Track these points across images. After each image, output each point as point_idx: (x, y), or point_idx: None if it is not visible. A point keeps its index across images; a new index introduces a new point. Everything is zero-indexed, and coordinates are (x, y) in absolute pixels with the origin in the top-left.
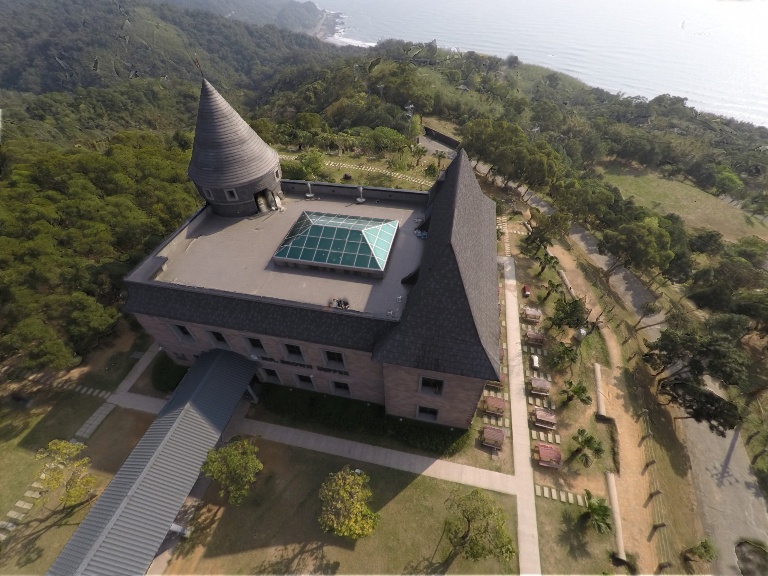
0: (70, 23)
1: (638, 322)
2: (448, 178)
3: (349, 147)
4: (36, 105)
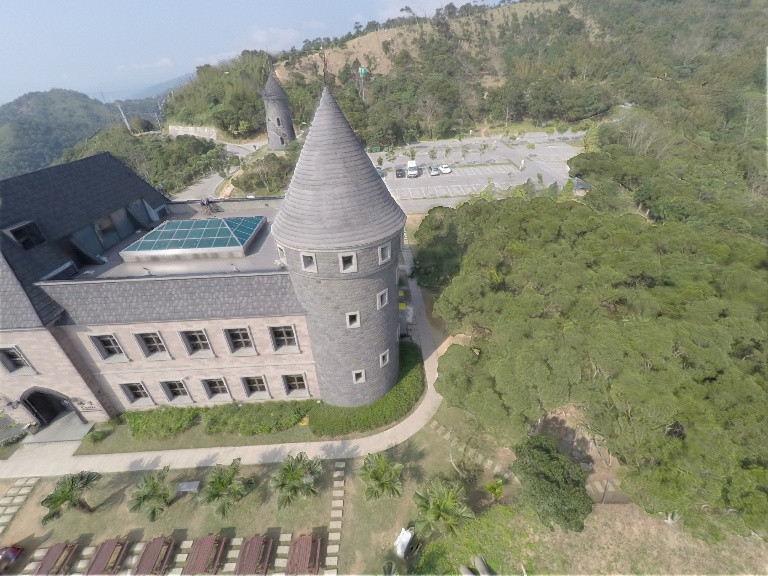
0: None
1: None
2: (24, 209)
3: None
4: None
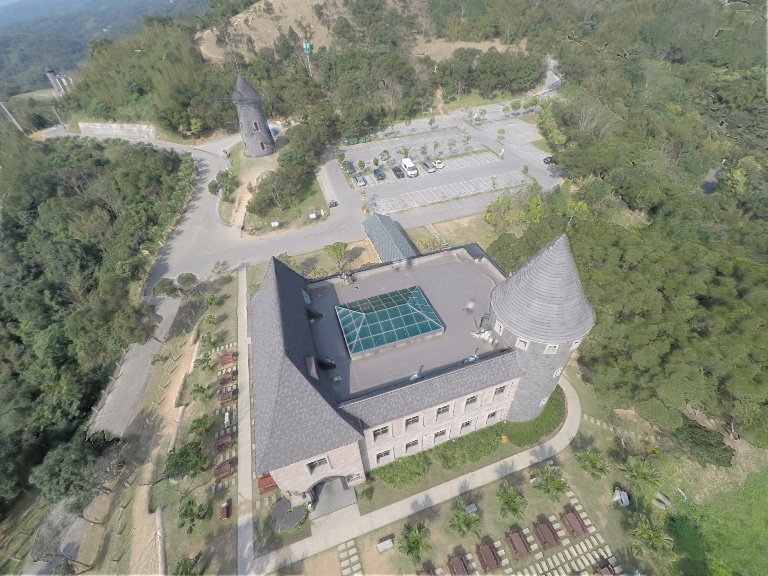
0: None
1: (85, 571)
2: None
3: None
4: None
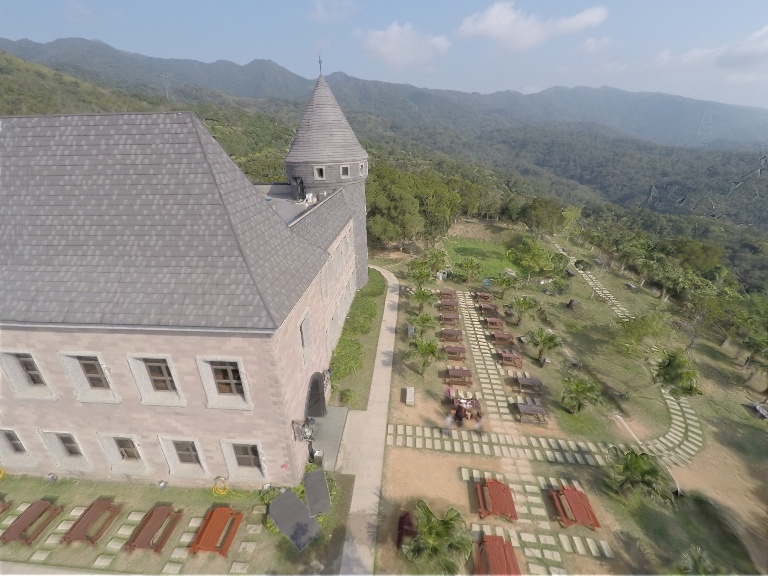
0: (697, 166)
1: None
2: None
3: (675, 295)
4: (592, 207)
